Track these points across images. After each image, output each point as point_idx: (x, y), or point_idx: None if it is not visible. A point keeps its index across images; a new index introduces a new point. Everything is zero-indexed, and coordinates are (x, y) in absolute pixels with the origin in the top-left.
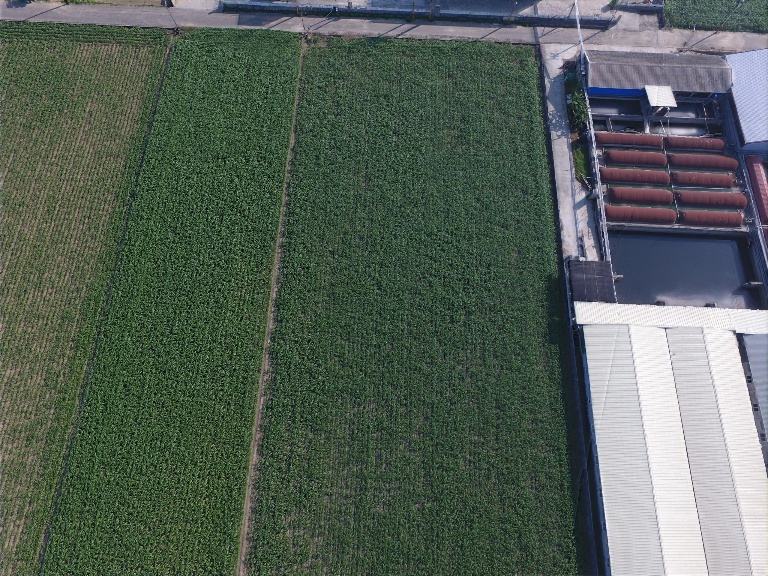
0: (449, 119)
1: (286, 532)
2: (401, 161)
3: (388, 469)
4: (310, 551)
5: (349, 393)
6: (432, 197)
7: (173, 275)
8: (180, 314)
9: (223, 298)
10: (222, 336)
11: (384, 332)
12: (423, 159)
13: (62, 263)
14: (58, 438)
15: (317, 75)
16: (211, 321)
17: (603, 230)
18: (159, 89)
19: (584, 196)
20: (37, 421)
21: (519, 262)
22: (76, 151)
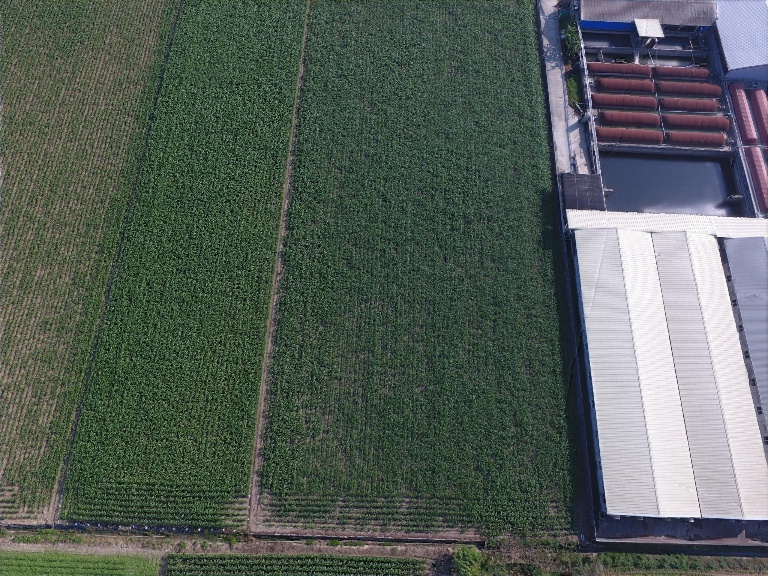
0: (449, 51)
1: (299, 410)
2: (404, 88)
3: (393, 357)
4: (321, 426)
5: (356, 291)
6: (433, 120)
7: (191, 187)
8: (198, 221)
9: (238, 208)
10: (238, 241)
11: (389, 238)
12: (425, 86)
13: (86, 178)
14: (86, 329)
15: (324, 11)
16: (227, 228)
17: (594, 148)
18: (175, 24)
19: (577, 120)
20: (67, 314)
21: (515, 178)
22: (97, 79)
